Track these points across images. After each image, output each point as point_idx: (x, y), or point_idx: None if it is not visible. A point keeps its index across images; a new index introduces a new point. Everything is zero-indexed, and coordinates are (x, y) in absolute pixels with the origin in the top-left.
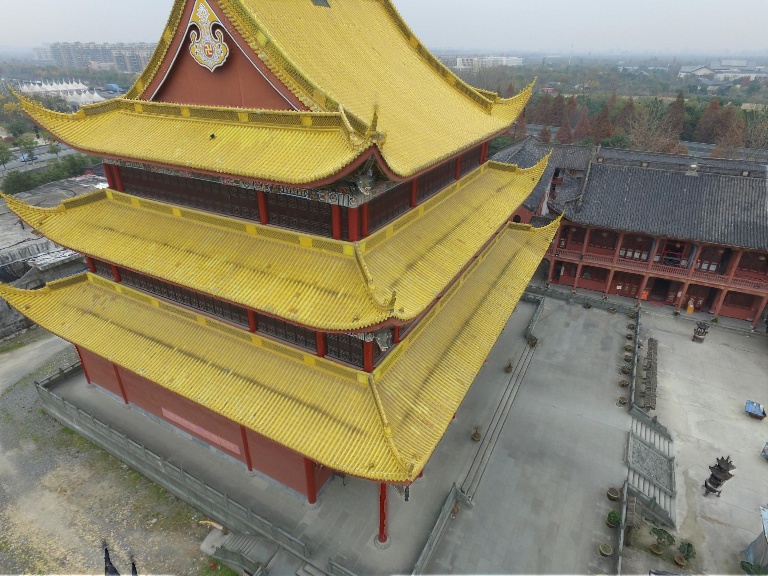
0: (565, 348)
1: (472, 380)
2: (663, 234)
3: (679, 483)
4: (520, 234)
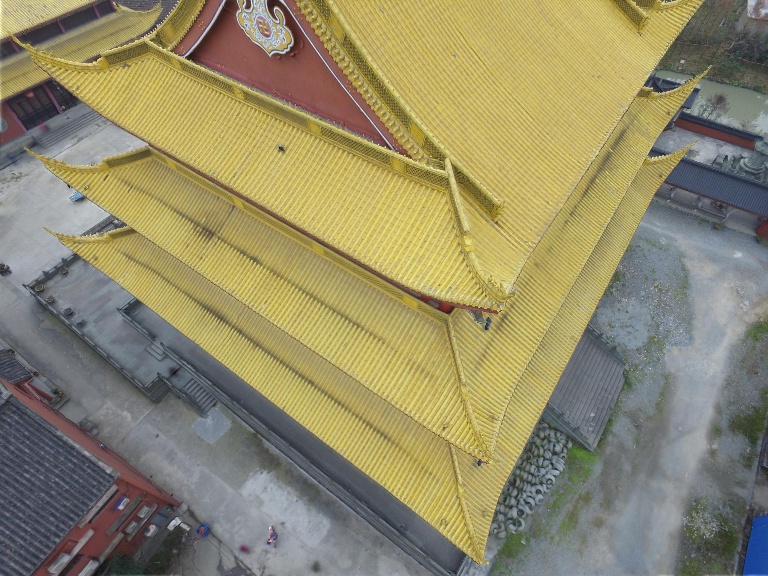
0: None
1: None
2: None
3: None
4: None
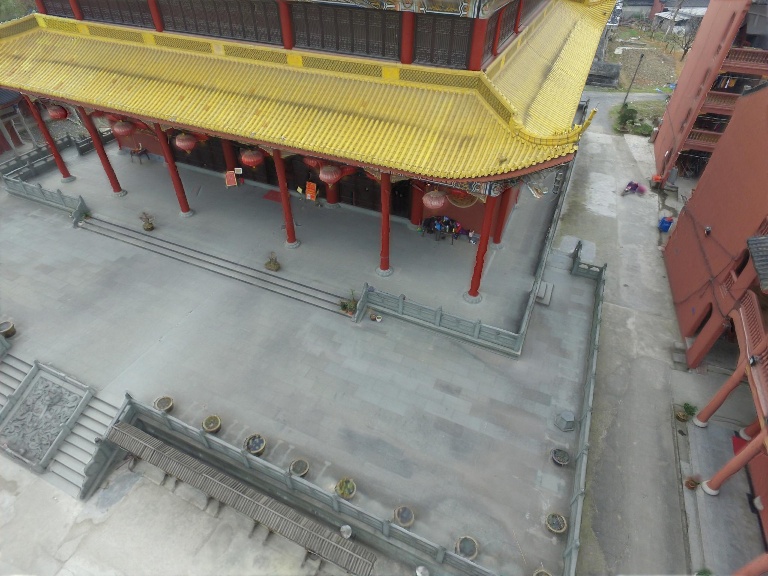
0: (349, 362)
1: (60, 94)
2: None
3: (2, 464)
4: (486, 117)
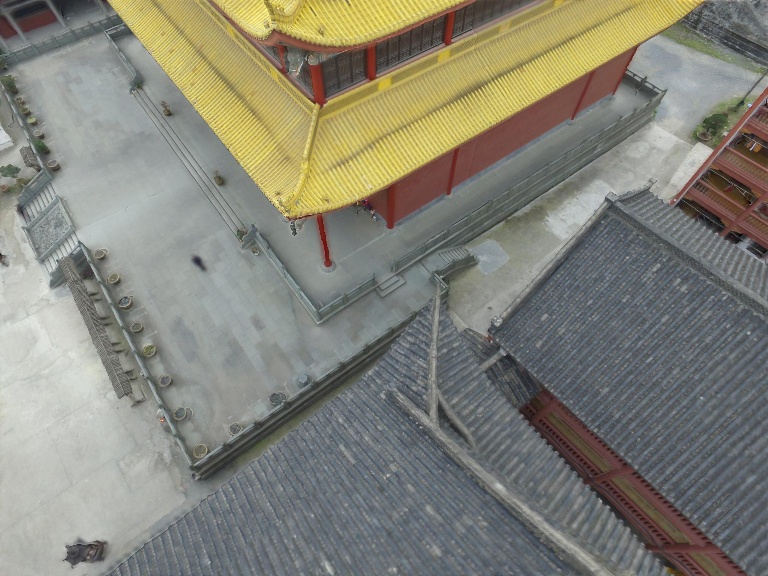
0: (215, 275)
1: None
2: (150, 541)
3: (28, 249)
4: None
